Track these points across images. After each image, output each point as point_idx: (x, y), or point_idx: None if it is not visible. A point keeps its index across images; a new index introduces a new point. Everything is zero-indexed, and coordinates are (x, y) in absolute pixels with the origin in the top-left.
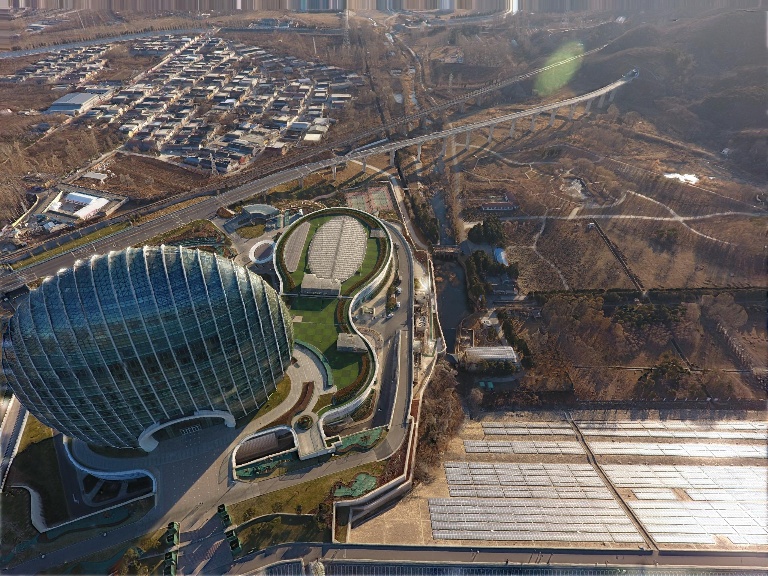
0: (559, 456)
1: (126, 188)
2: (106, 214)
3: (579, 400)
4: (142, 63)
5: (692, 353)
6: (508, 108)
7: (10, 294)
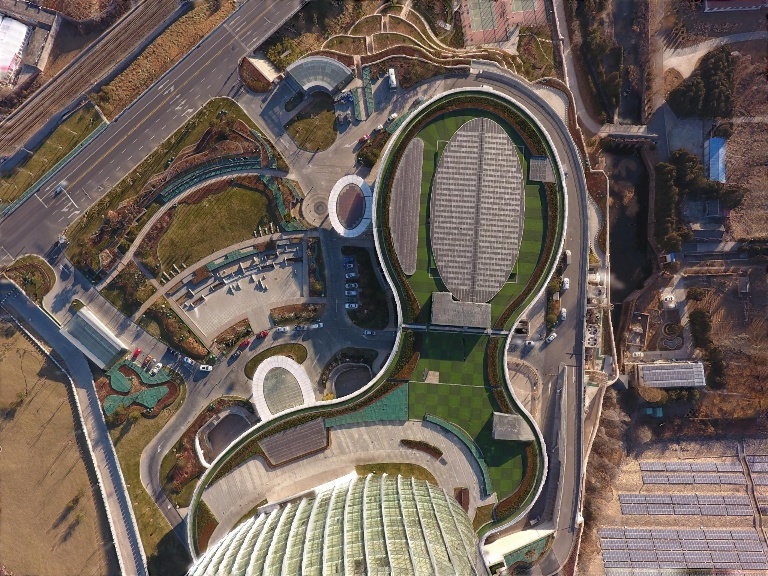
0: (723, 518)
1: None
2: (39, 69)
3: (761, 428)
4: None
5: None
6: None
7: None
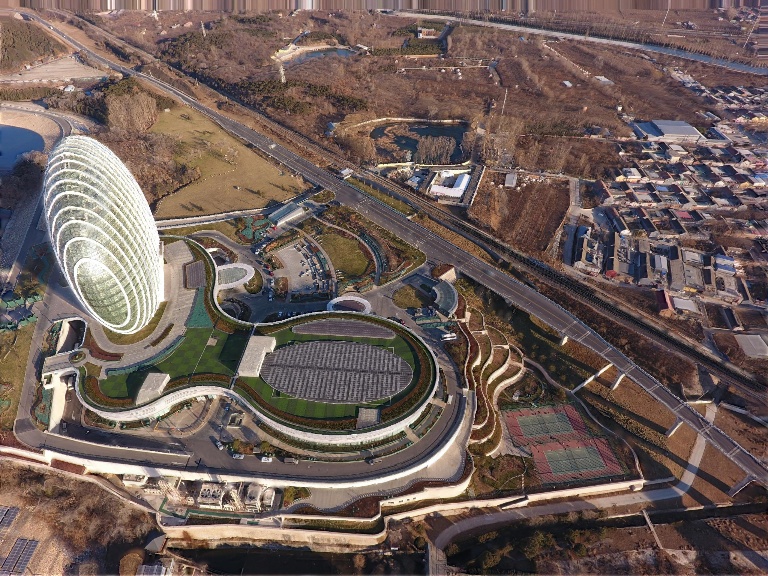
0: None
1: None
2: (438, 201)
3: None
4: None
5: None
6: None
7: (321, 188)
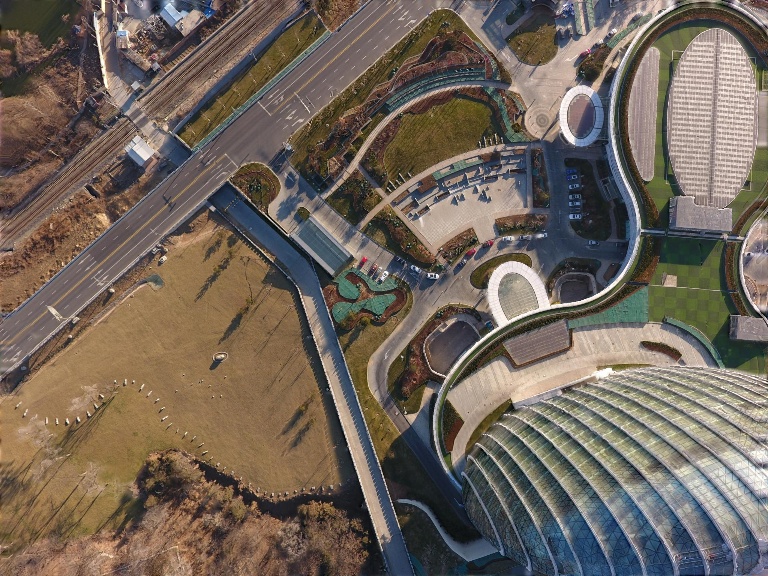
0: None
1: None
2: None
3: None
4: None
5: None
6: None
7: None
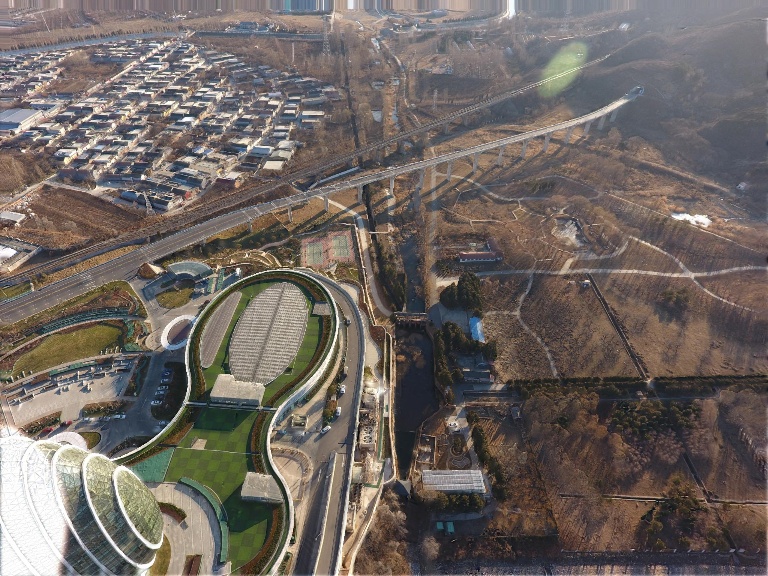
0: None
1: (42, 233)
2: (9, 270)
3: (564, 551)
4: (101, 72)
5: (709, 474)
6: (498, 129)
7: None
